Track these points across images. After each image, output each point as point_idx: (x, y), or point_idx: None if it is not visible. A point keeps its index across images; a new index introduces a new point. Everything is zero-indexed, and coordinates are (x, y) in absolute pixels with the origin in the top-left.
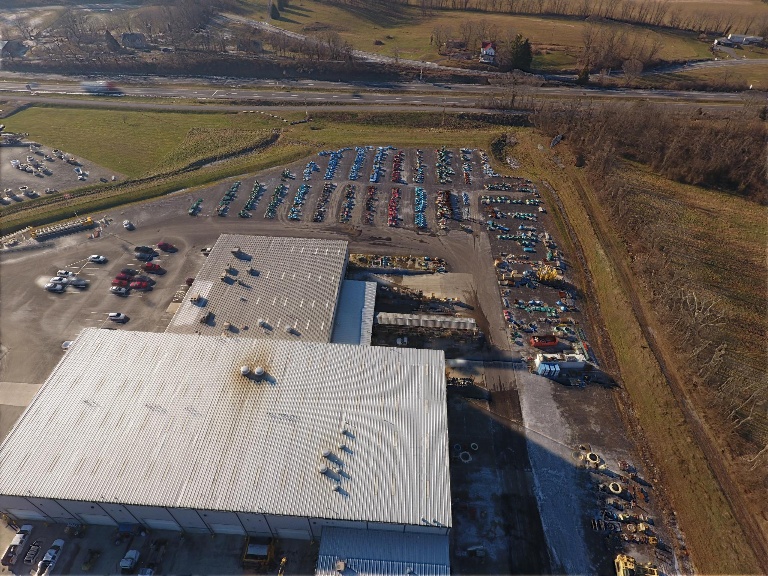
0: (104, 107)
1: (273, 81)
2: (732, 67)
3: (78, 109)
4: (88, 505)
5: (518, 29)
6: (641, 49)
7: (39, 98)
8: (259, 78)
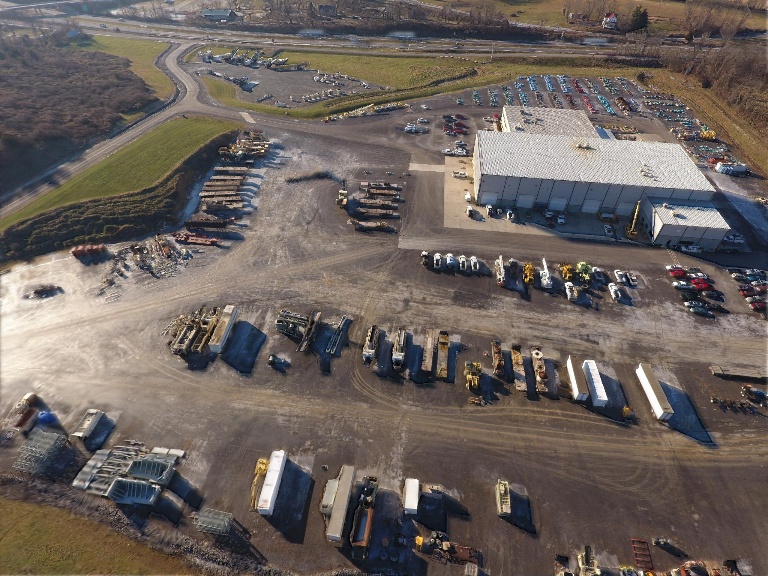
0: (335, 53)
1: (447, 39)
2: None
3: (317, 54)
4: (535, 184)
5: None
6: (732, 19)
7: (284, 47)
8: (435, 37)
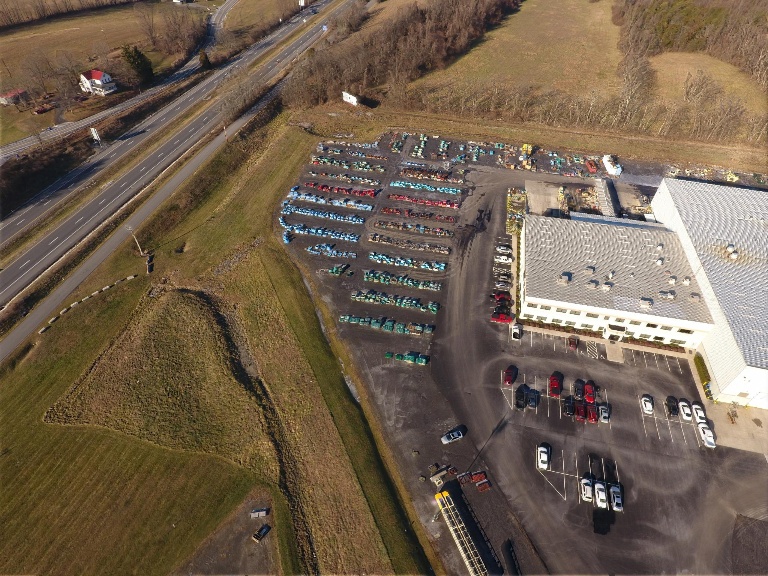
0: None
1: None
2: (234, 14)
3: None
4: None
5: (44, 51)
6: (192, 22)
7: None
8: None
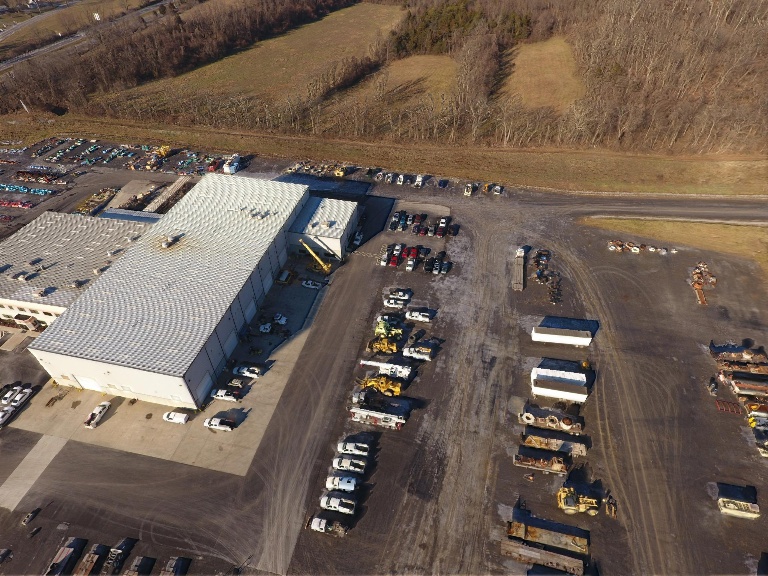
0: None
1: None
2: (23, 30)
3: None
4: (227, 319)
5: None
6: None
7: None
8: None
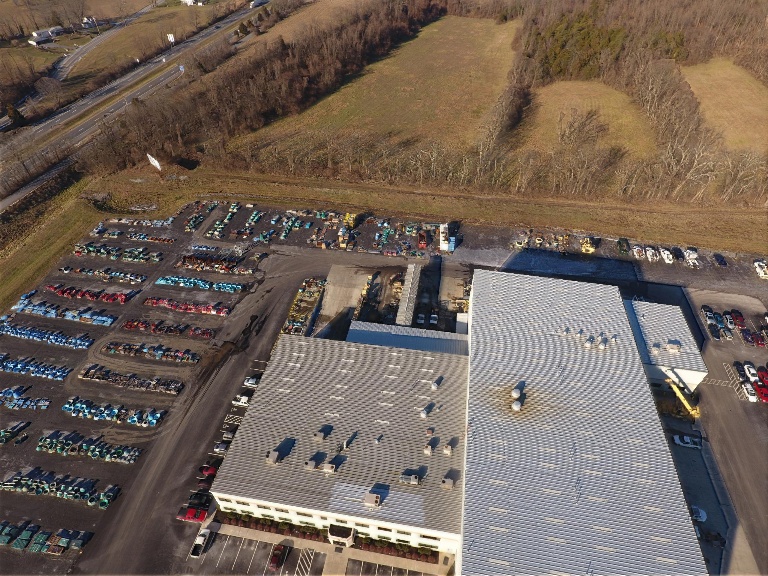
0: None
1: None
2: (90, 55)
3: None
4: None
5: None
6: (17, 69)
7: None
8: None
